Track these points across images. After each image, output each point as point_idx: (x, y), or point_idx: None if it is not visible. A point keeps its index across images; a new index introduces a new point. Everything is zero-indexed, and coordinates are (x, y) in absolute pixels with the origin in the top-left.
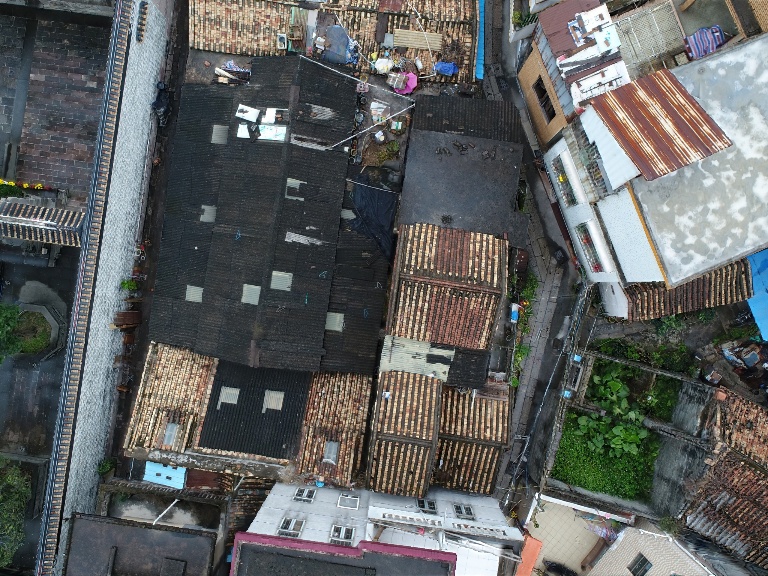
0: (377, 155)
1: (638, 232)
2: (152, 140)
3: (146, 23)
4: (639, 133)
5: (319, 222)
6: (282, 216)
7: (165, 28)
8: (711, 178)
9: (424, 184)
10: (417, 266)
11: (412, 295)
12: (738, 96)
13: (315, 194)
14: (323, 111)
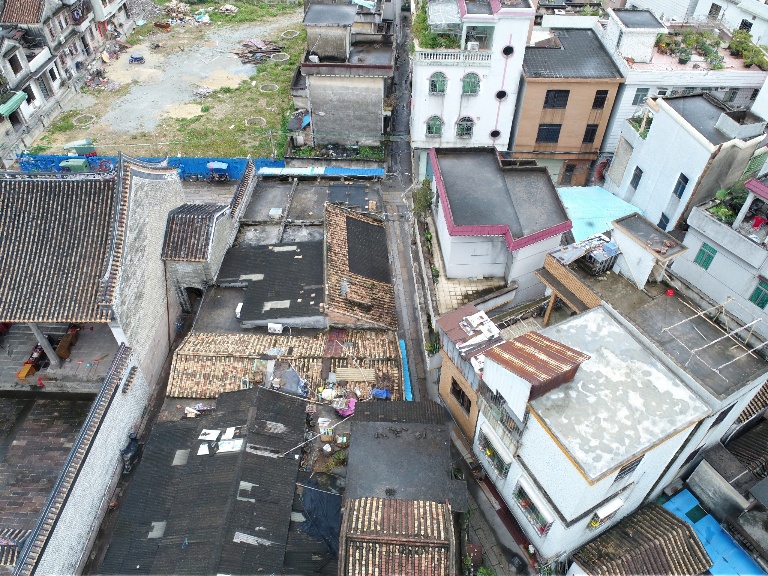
0: (325, 465)
1: (553, 451)
2: (113, 484)
3: (132, 384)
4: (522, 363)
5: (269, 523)
6: (232, 517)
7: (146, 395)
8: (593, 396)
9: (366, 463)
10: (364, 528)
11: (361, 559)
12: (590, 344)
13: (266, 496)
14: (276, 426)
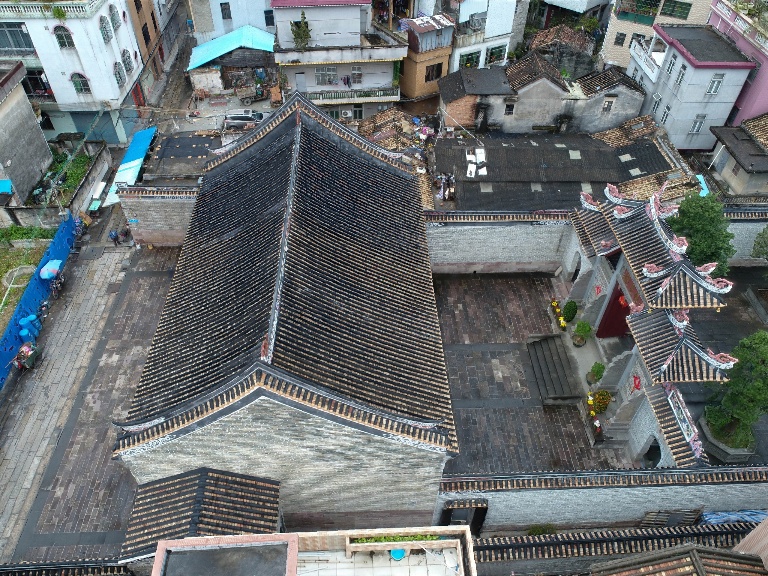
0: None
1: None
2: None
3: None
4: None
5: None
6: None
7: None
8: None
9: None
10: None
11: None
12: None
13: None
14: None
